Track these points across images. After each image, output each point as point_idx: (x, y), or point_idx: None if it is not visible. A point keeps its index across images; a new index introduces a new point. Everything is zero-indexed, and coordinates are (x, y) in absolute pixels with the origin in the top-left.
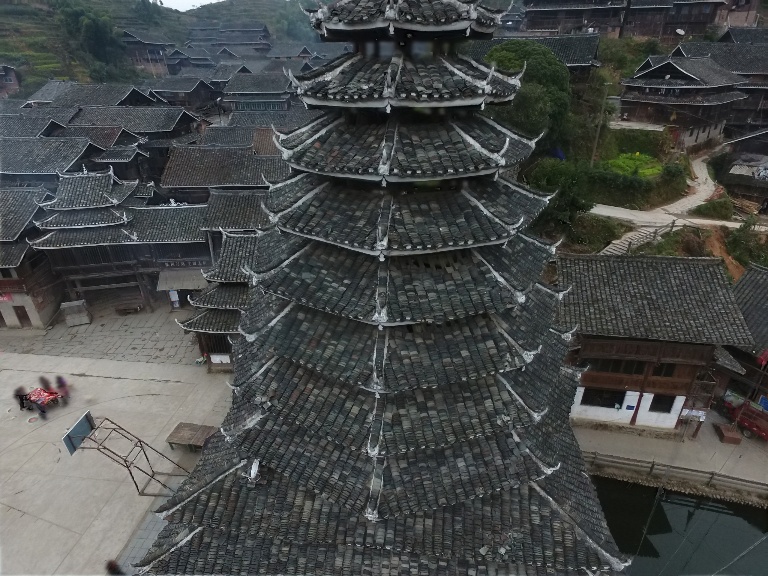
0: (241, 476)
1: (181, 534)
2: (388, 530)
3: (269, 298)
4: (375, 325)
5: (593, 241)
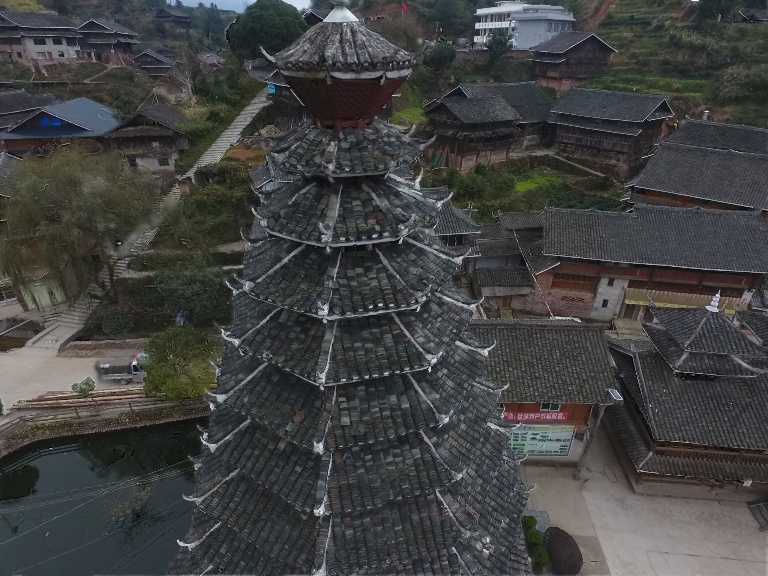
0: None
1: None
2: None
3: None
4: None
5: None
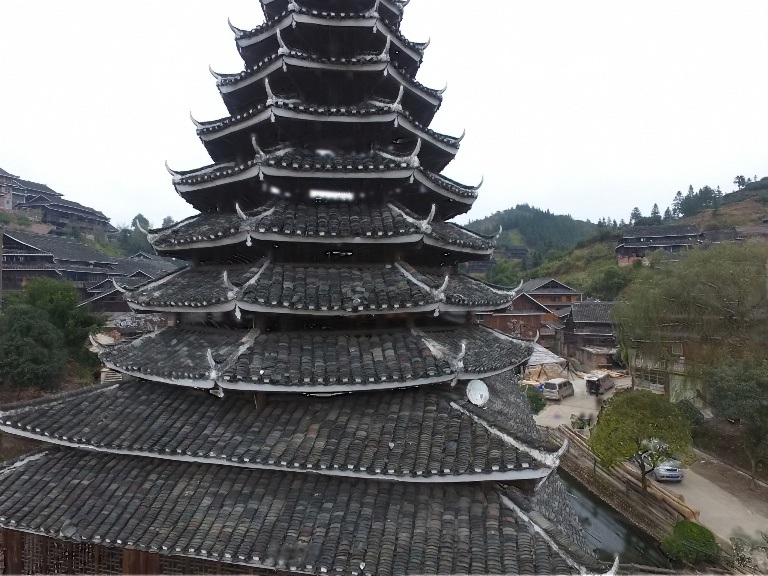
0: (482, 409)
1: (540, 520)
2: (509, 394)
3: (346, 220)
4: (470, 205)
5: (83, 375)
